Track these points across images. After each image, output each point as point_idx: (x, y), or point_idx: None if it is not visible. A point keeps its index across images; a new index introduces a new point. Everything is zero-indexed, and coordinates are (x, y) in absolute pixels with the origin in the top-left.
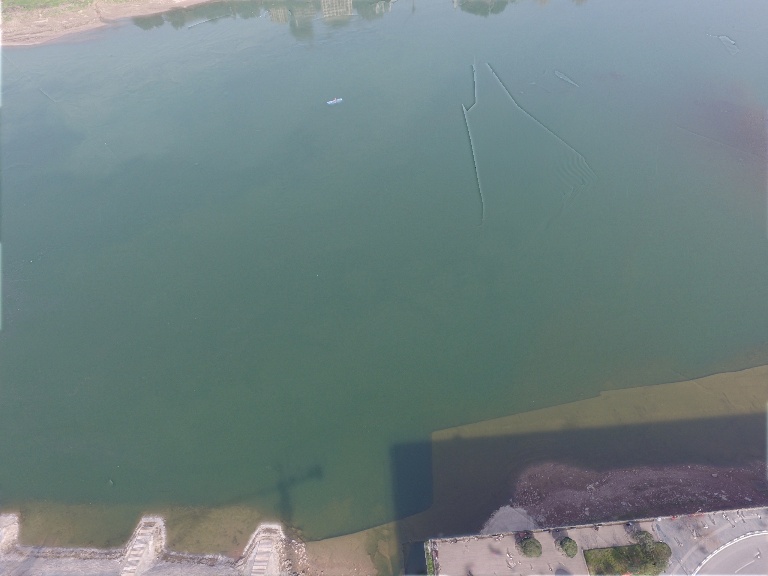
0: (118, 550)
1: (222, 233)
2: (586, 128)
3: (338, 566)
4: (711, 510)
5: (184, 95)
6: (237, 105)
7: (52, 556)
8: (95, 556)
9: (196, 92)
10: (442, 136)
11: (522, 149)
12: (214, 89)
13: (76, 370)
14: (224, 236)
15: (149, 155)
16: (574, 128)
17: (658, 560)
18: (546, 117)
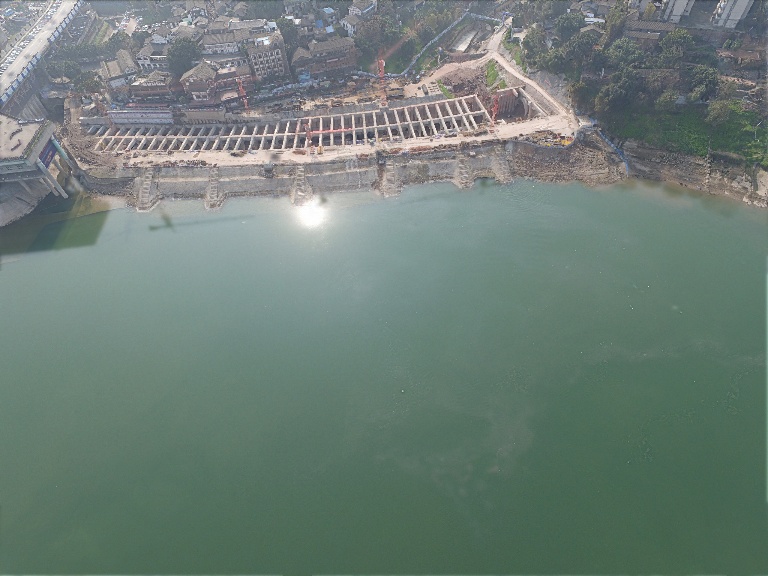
0: (230, 198)
1: (165, 466)
2: None
3: (110, 200)
4: None
5: None
6: None
7: (264, 192)
8: (240, 193)
9: None
10: None
11: None
12: None
13: (295, 282)
14: (163, 460)
15: None
16: None
17: None
18: None
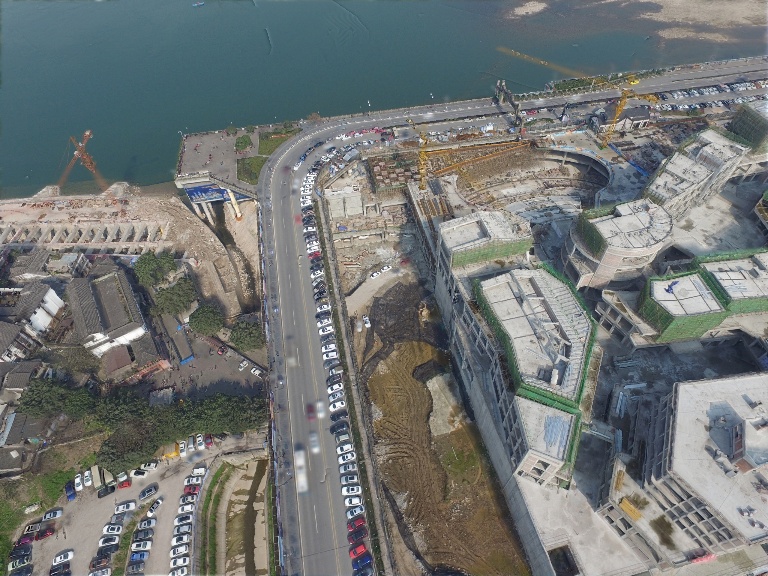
0: None
1: (105, 76)
2: (382, 12)
3: (157, 192)
4: None
5: (84, 9)
6: None
7: None
8: None
9: (93, 7)
10: None
11: None
12: (107, 4)
13: (4, 139)
14: (107, 78)
15: (54, 40)
16: (371, 12)
17: (289, 126)
18: (350, 4)
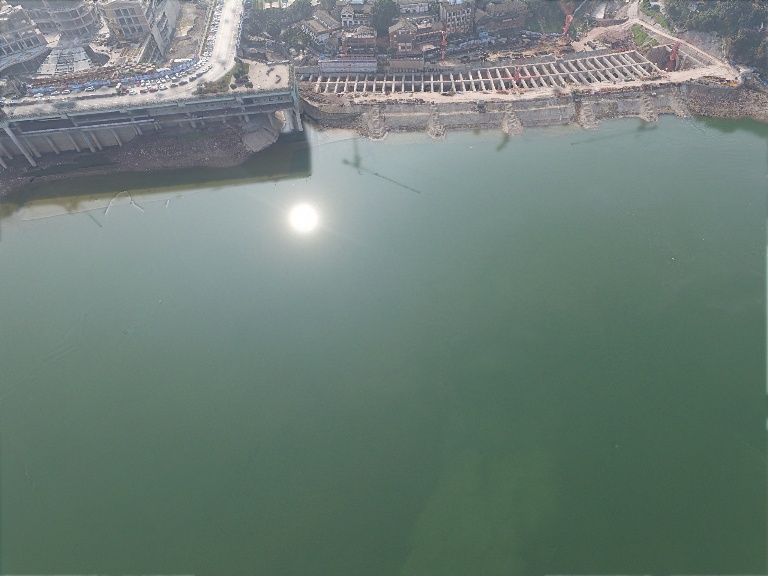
0: (449, 129)
1: (498, 312)
2: None
3: (342, 132)
4: (155, 141)
5: None
6: None
7: (478, 124)
8: (458, 126)
9: None
10: (175, 557)
11: None
12: None
13: (540, 189)
14: (493, 309)
15: (705, 444)
16: None
17: None
18: None
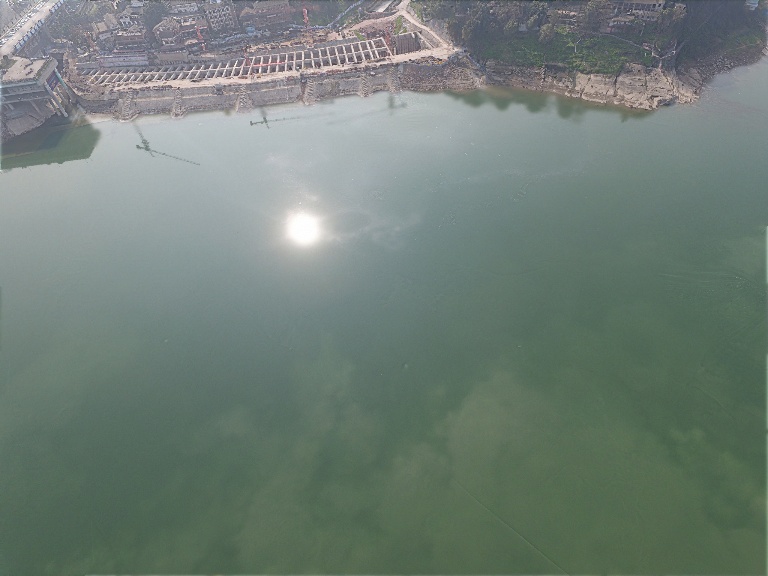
0: (190, 110)
1: (138, 249)
2: None
3: (100, 116)
4: None
5: (205, 560)
6: (86, 502)
7: (216, 105)
8: (198, 107)
9: (177, 575)
10: None
11: None
12: None
13: (234, 154)
14: (137, 247)
15: (223, 333)
16: None
17: None
18: None
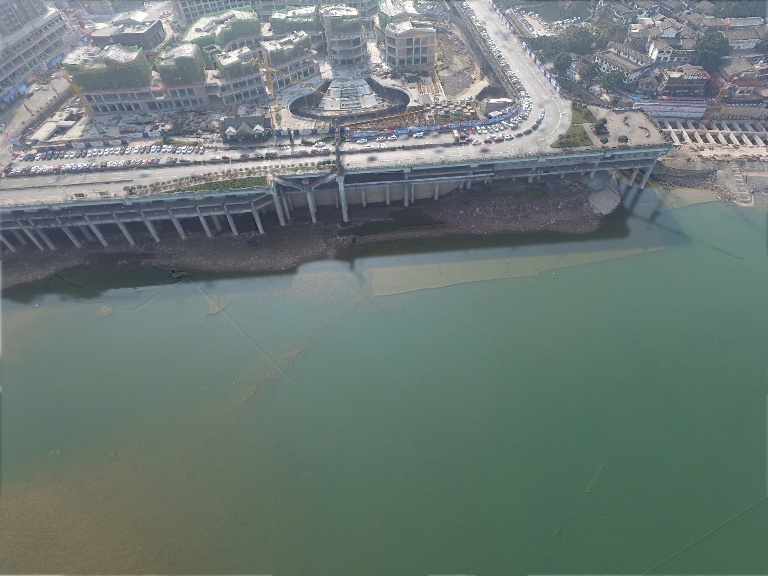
0: None
1: None
2: None
3: (694, 193)
4: (492, 199)
5: None
6: None
7: None
8: None
9: None
10: None
11: (735, 449)
12: None
13: None
14: None
15: None
16: None
17: None
18: None
